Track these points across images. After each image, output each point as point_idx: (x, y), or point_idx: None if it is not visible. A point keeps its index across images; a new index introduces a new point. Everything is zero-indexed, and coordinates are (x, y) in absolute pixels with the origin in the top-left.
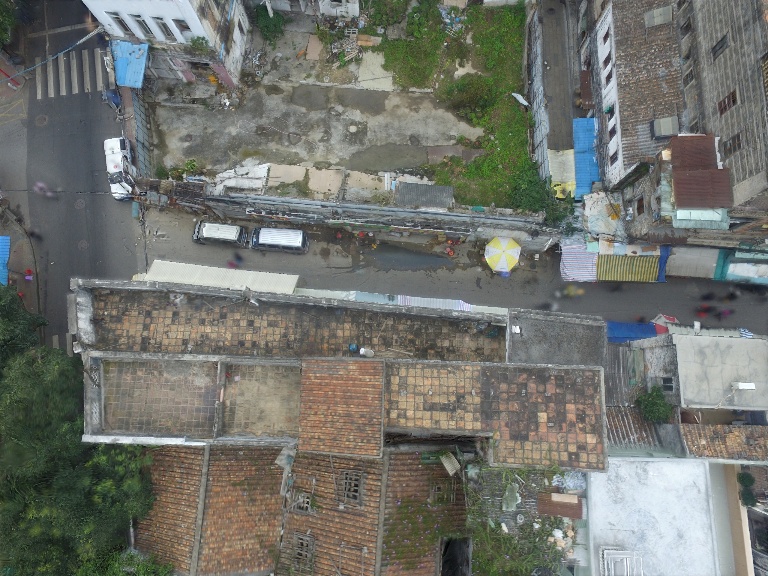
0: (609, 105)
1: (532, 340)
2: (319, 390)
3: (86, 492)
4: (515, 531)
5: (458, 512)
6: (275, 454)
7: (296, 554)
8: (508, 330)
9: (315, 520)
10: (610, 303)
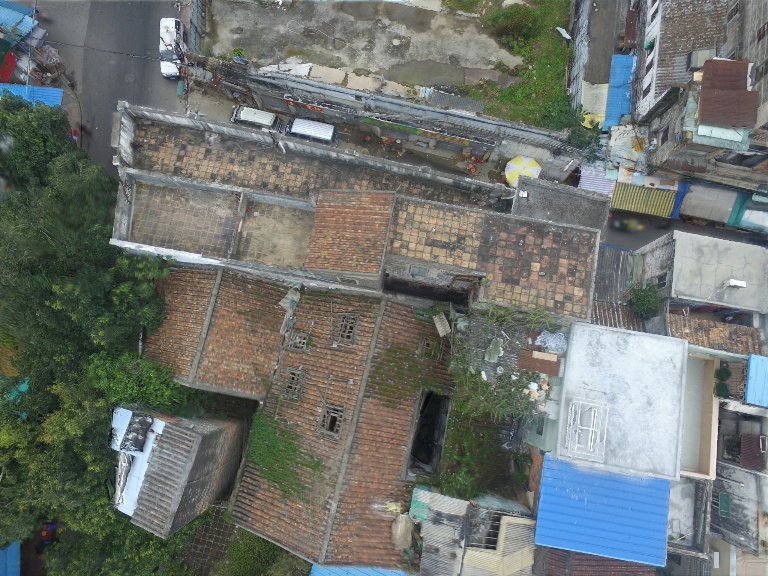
0: (650, 40)
1: (537, 206)
2: (331, 217)
3: (106, 292)
4: (493, 380)
5: (442, 371)
6: (280, 296)
7: (286, 387)
8: (516, 192)
9: (308, 358)
10: (621, 239)
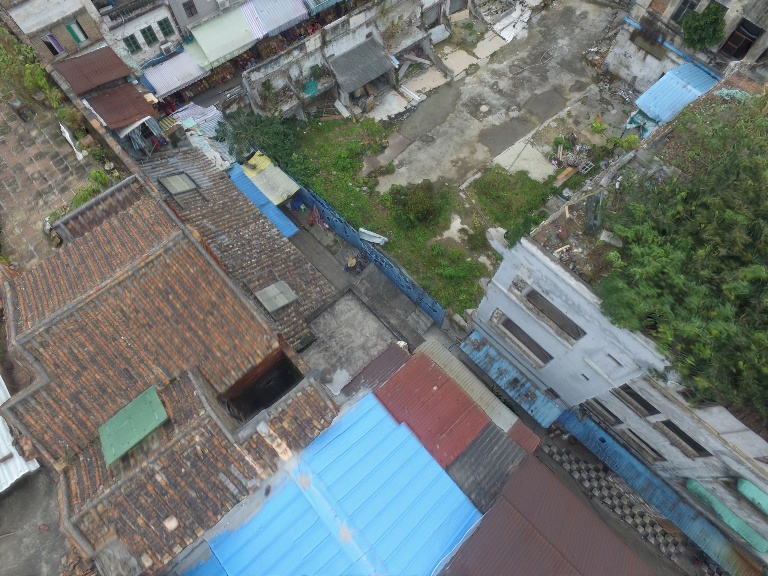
0: None
1: None
2: None
3: None
4: None
5: None
6: None
7: None
8: None
9: None
10: None
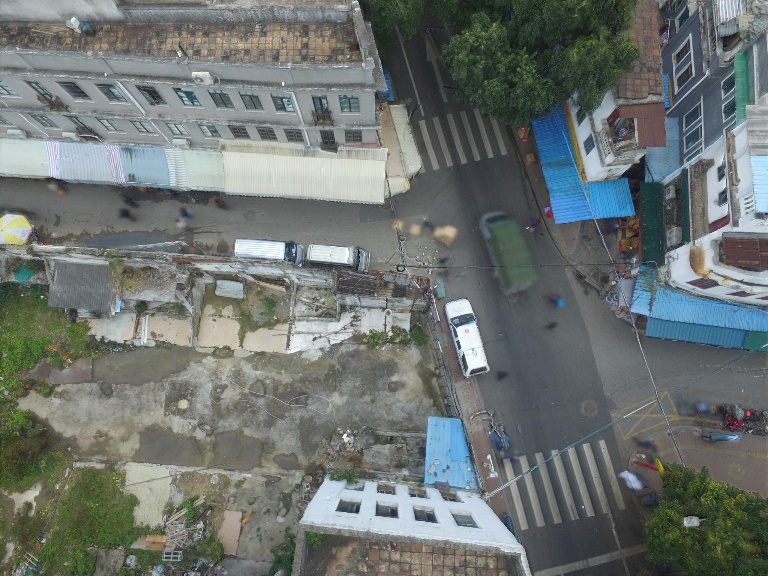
0: None
1: None
2: None
3: None
4: None
5: None
6: None
7: None
8: None
9: None
10: None
